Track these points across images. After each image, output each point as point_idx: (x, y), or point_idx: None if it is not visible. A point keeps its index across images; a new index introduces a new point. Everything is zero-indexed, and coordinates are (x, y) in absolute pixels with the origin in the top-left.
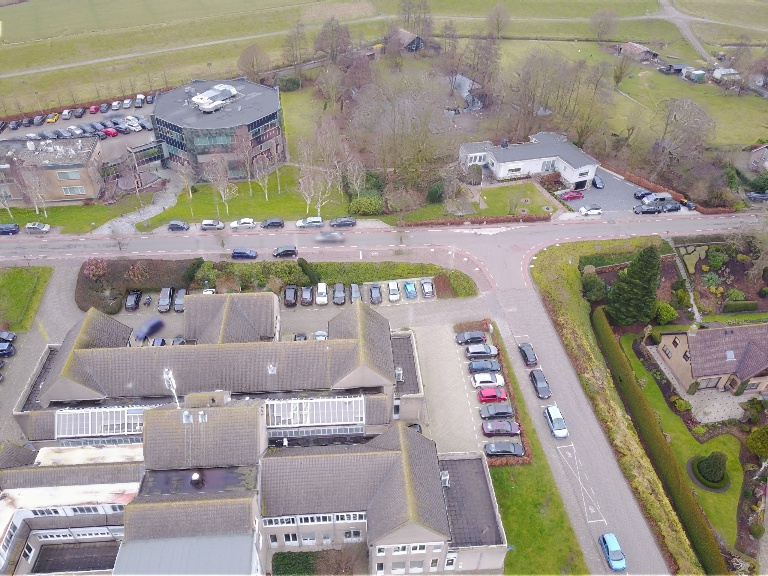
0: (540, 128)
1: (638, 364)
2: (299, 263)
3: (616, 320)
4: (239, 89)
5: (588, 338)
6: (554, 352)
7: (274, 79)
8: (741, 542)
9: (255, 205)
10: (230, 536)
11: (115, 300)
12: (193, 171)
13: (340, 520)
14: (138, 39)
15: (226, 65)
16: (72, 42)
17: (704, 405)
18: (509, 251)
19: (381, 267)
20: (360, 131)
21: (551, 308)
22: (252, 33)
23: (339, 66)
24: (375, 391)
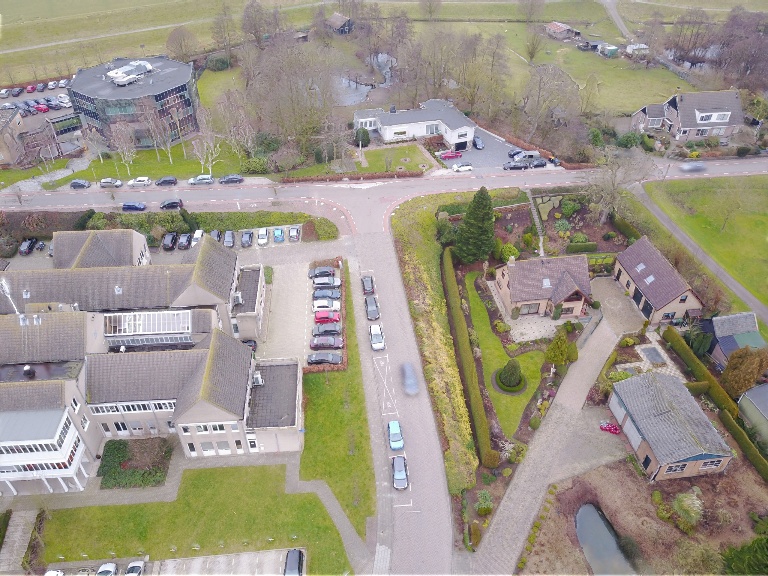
0: (447, 100)
1: (475, 296)
2: (181, 213)
3: (460, 258)
4: (157, 65)
5: (431, 273)
6: (393, 283)
7: (206, 60)
8: (519, 432)
9: (159, 168)
10: (45, 411)
11: (11, 246)
12: (101, 137)
13: (159, 409)
14: (83, 25)
15: (165, 48)
16: (19, 29)
17: (523, 328)
18: (377, 202)
19: (255, 216)
20: (255, 99)
21: (400, 248)
22: (194, 19)
23: (263, 46)
24: (208, 308)
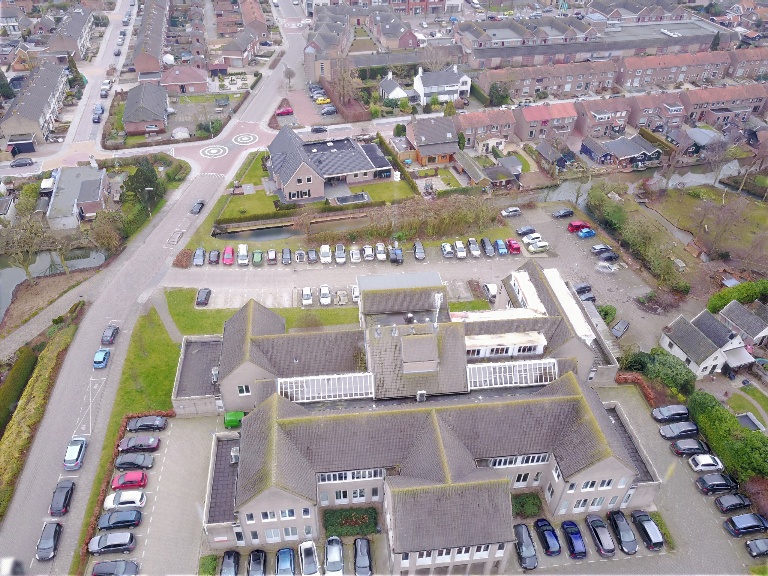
0: None
1: None
2: None
3: None
4: None
5: None
6: (7, 552)
7: None
8: None
9: None
10: None
11: None
12: None
13: None
14: None
15: None
16: None
17: None
18: None
19: None
20: None
21: None
22: None
23: None
24: None
